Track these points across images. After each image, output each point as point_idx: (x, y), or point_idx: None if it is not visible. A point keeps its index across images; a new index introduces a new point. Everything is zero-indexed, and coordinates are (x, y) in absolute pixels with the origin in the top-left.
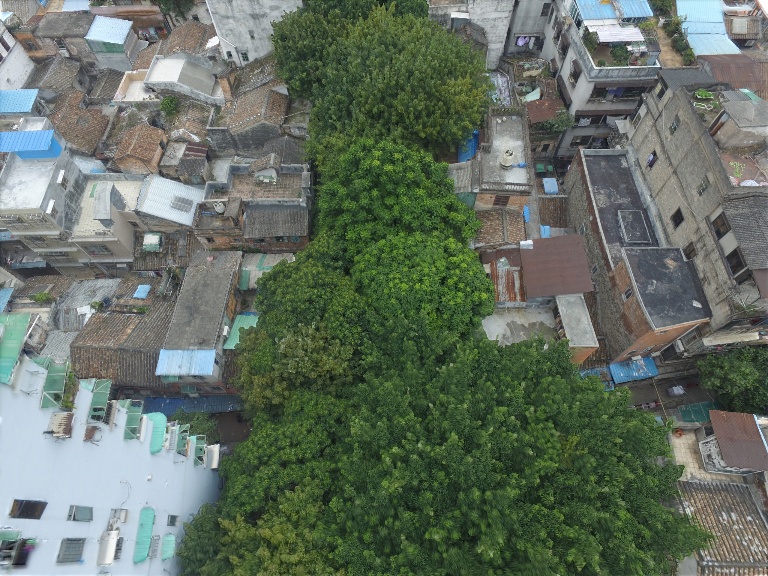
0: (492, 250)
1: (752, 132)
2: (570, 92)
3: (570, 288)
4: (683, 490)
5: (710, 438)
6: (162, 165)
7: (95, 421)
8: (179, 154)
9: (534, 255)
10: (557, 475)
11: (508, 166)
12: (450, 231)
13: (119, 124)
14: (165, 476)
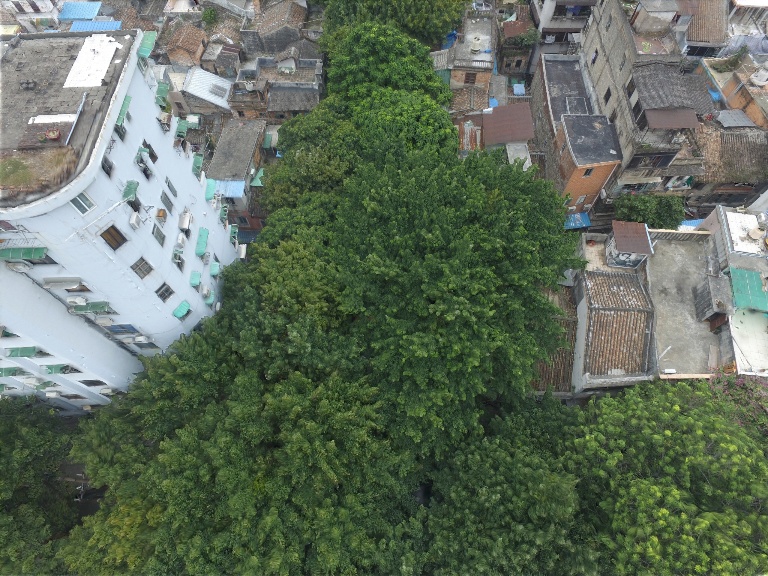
0: (461, 117)
1: (658, 18)
2: (539, 14)
3: (517, 137)
4: (588, 275)
5: (611, 240)
6: (203, 59)
7: (180, 138)
8: (217, 52)
9: (493, 117)
10: (483, 215)
11: (476, 50)
12: (428, 95)
13: (168, 30)
14: (213, 226)
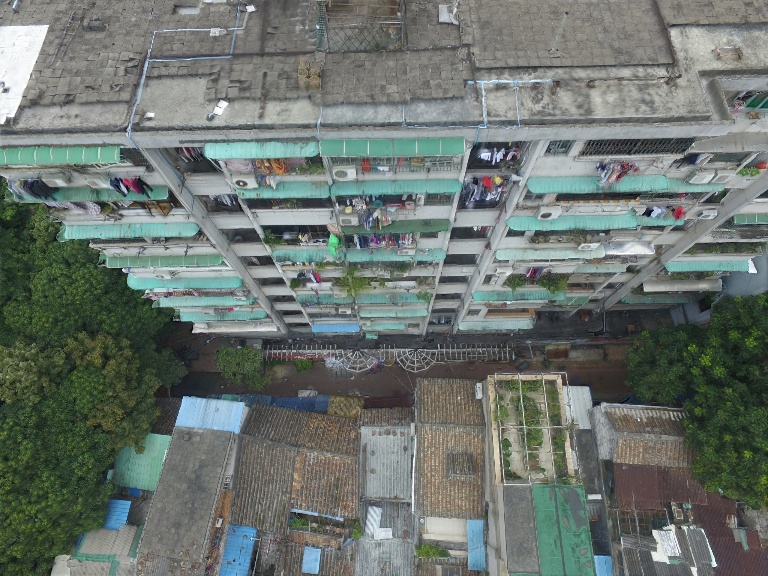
0: None
1: None
2: None
3: None
4: None
5: None
6: None
7: None
8: None
9: None
10: None
11: None
12: None
13: None
14: None
